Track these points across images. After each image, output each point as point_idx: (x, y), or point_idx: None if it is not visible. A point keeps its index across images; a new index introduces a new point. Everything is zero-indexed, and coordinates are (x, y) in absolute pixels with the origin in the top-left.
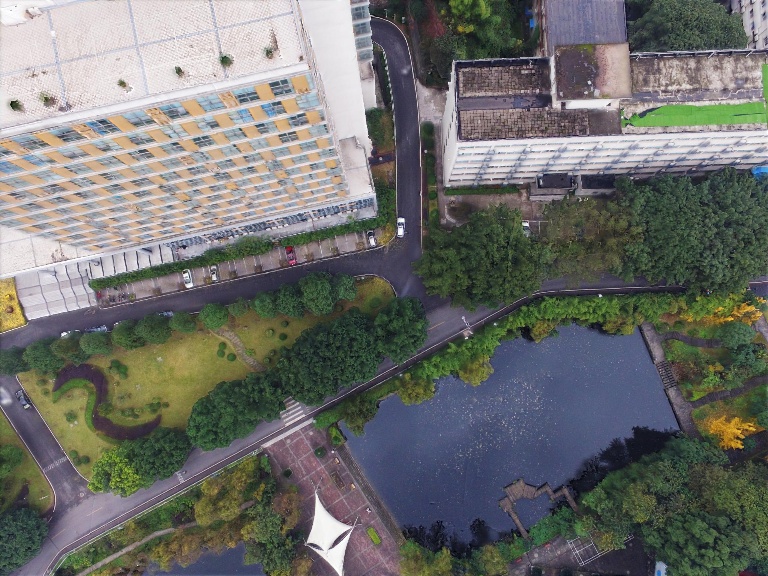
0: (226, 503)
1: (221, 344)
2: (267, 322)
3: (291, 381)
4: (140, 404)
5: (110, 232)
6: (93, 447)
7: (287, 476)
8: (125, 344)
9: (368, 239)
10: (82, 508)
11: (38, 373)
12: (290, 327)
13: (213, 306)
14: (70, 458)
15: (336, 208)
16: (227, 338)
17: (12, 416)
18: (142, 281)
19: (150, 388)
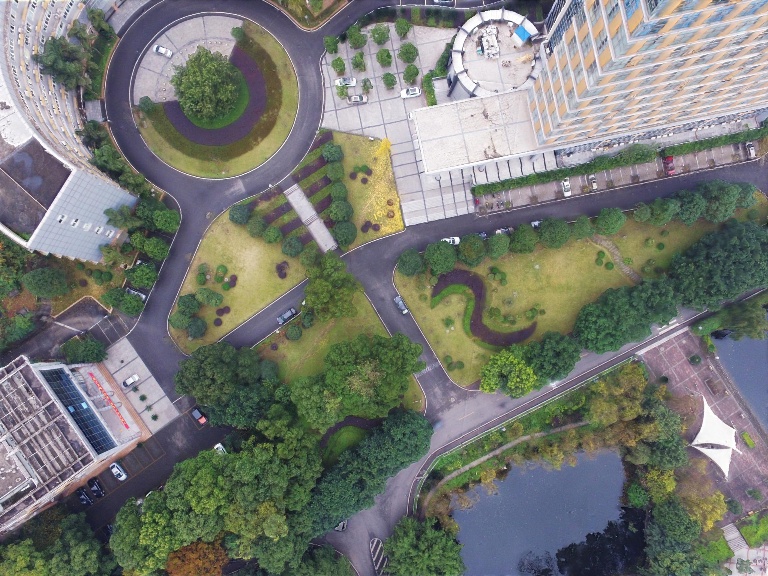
0: (630, 403)
1: (601, 252)
2: (645, 232)
3: (700, 284)
4: (516, 311)
5: (602, 119)
6: (468, 353)
7: (666, 382)
8: (527, 247)
9: (748, 150)
10: (453, 412)
11: (424, 278)
12: (667, 237)
13: (620, 210)
14: (443, 364)
15: (733, 116)
16: (605, 247)
17: (387, 321)
18: (519, 189)
19: (527, 295)
